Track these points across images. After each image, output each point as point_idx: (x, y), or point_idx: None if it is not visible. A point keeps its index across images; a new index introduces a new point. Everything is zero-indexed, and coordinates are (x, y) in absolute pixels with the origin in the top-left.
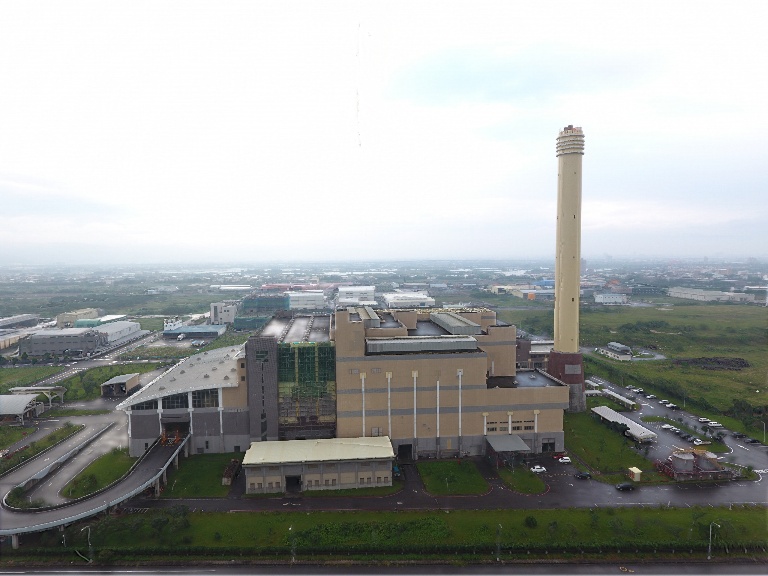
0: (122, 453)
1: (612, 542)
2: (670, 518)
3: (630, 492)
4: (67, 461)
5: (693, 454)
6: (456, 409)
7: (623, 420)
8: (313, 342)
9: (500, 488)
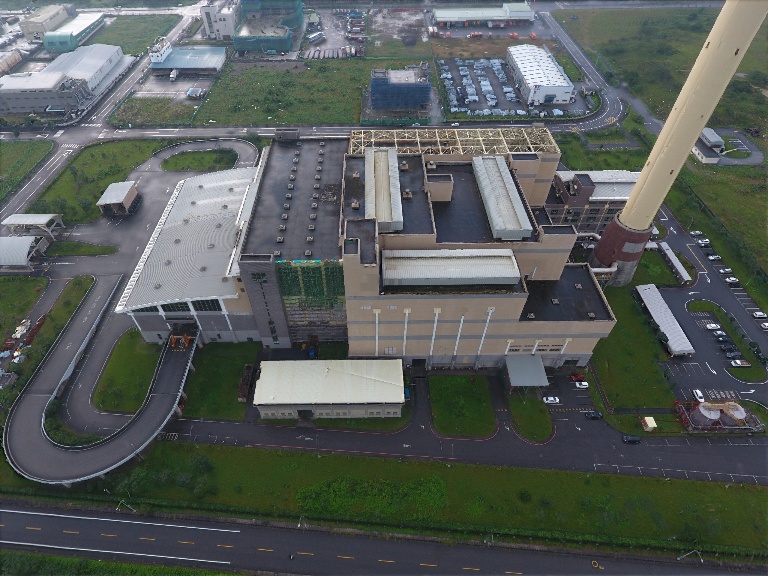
0: (138, 336)
1: (594, 538)
2: (661, 498)
3: (635, 447)
4: (88, 346)
5: (721, 411)
6: (479, 336)
7: (666, 317)
8: (318, 261)
9: (506, 429)
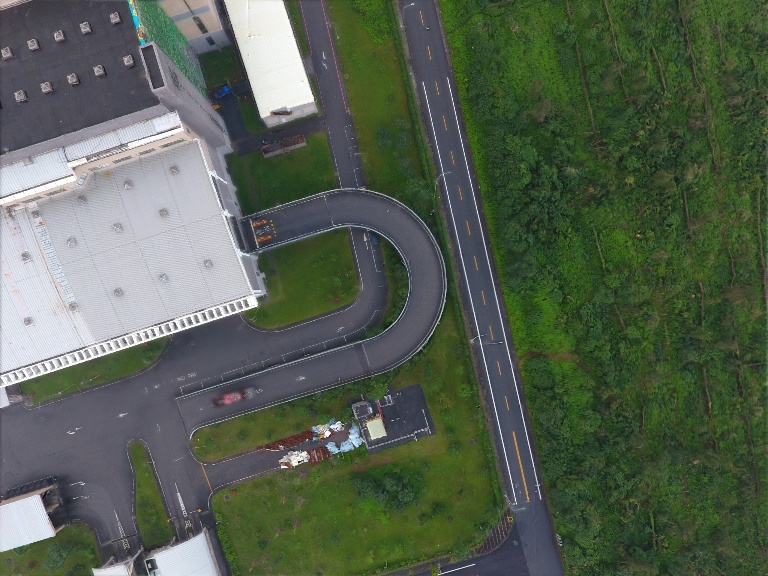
0: (261, 309)
1: None
2: None
3: None
4: (291, 359)
5: None
6: None
7: None
8: None
9: None
